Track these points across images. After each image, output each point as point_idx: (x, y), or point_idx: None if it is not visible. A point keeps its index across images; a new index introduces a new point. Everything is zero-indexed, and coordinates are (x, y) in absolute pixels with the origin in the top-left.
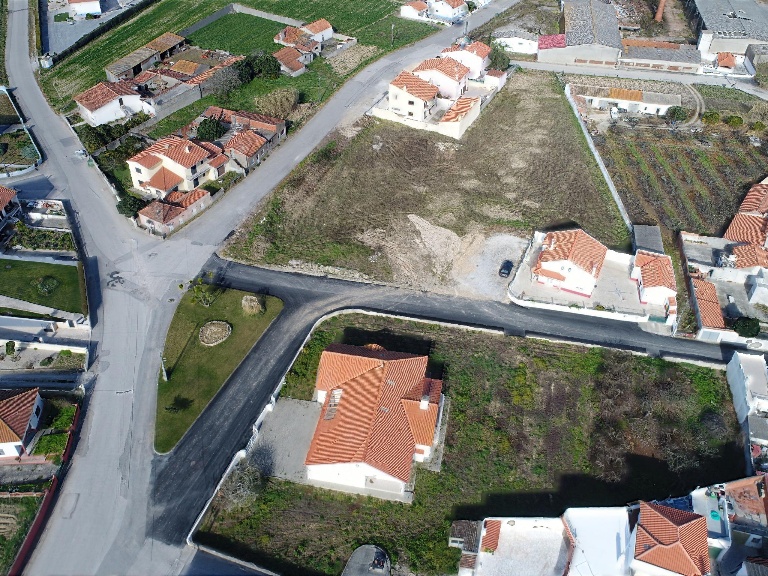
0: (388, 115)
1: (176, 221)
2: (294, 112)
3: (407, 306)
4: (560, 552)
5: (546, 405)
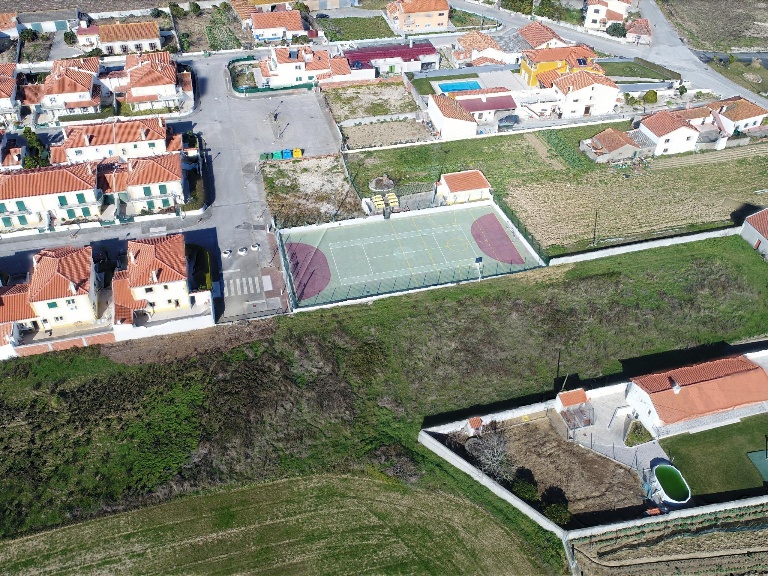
0: None
1: None
2: None
3: None
4: None
5: None
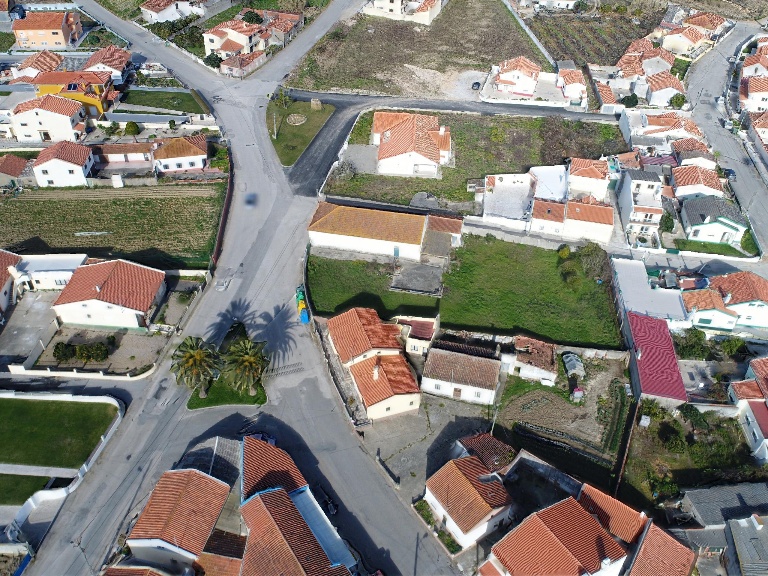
0: (375, 12)
1: (247, 69)
2: (306, 12)
3: (416, 105)
4: (530, 191)
5: (512, 141)
